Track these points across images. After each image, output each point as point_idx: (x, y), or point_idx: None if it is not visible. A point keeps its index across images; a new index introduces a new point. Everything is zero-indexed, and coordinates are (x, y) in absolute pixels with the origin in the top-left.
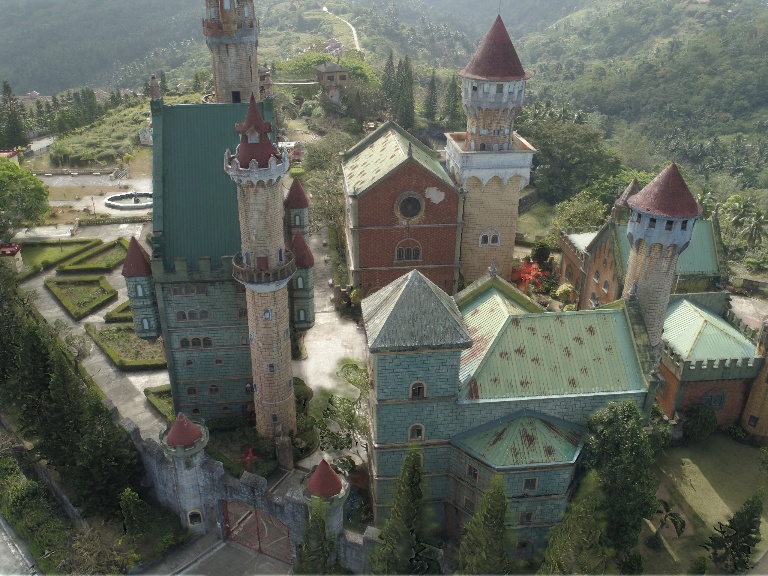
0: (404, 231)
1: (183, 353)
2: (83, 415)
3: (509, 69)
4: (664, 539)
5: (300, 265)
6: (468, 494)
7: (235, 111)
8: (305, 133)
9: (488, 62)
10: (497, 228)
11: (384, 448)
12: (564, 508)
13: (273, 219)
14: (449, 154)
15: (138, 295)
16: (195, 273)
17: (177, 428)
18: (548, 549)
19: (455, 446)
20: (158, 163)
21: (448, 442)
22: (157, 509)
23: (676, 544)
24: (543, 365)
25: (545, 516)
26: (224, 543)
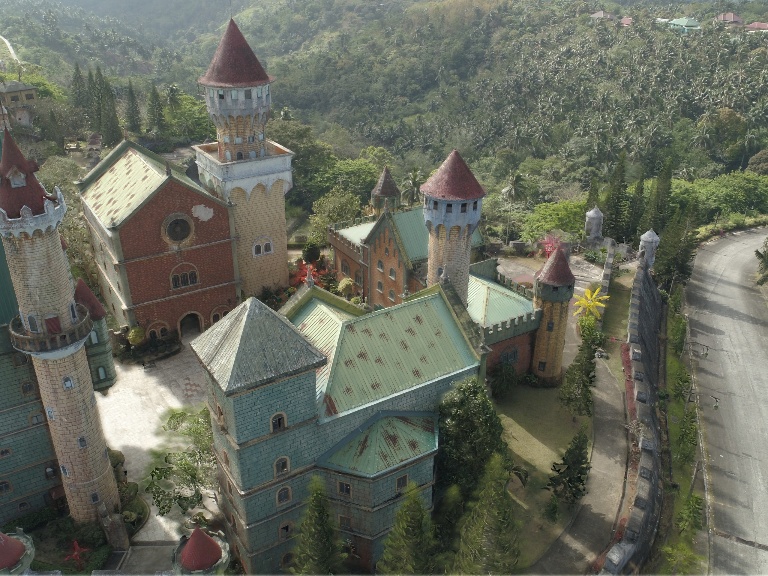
0: (176, 256)
1: None
2: None
3: (253, 74)
4: (510, 493)
5: (91, 317)
6: (342, 512)
7: None
8: None
9: (231, 68)
10: (268, 236)
11: (251, 493)
12: (431, 494)
13: (58, 272)
14: (203, 168)
15: None
16: None
17: None
18: (464, 540)
19: (322, 468)
20: None
21: (314, 466)
22: None
23: (521, 494)
24: (387, 364)
25: None
26: None
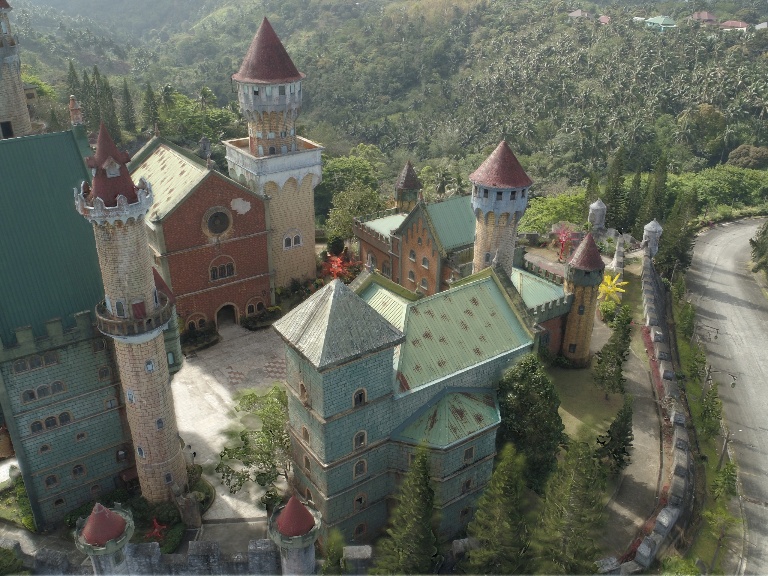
0: (215, 249)
1: (35, 439)
2: None
3: (287, 70)
4: None
5: None
6: None
7: (39, 144)
8: None
9: (265, 65)
10: (298, 229)
11: (333, 466)
12: None
13: (145, 259)
14: (235, 163)
15: None
16: (44, 341)
17: (98, 522)
18: (550, 499)
19: (395, 441)
20: None
21: (388, 440)
22: None
23: None
24: (450, 343)
25: (480, 479)
26: None
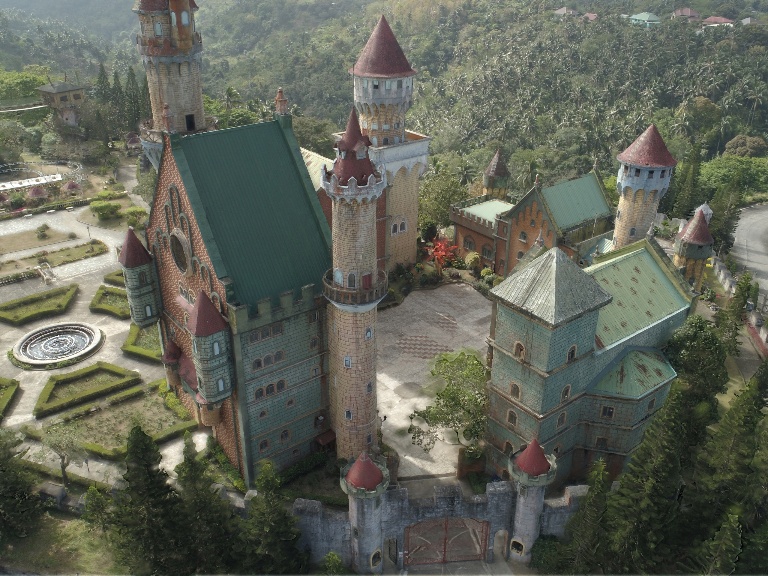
0: None
1: (257, 406)
2: (214, 504)
3: (403, 65)
4: None
5: None
6: (601, 433)
7: (253, 133)
8: (60, 163)
9: (385, 60)
10: (404, 216)
11: (545, 417)
12: None
13: None
14: None
15: (214, 354)
16: (278, 312)
17: (366, 469)
18: None
19: (590, 395)
20: (197, 203)
21: (584, 394)
22: (318, 571)
23: None
24: (626, 306)
25: None
26: (405, 571)
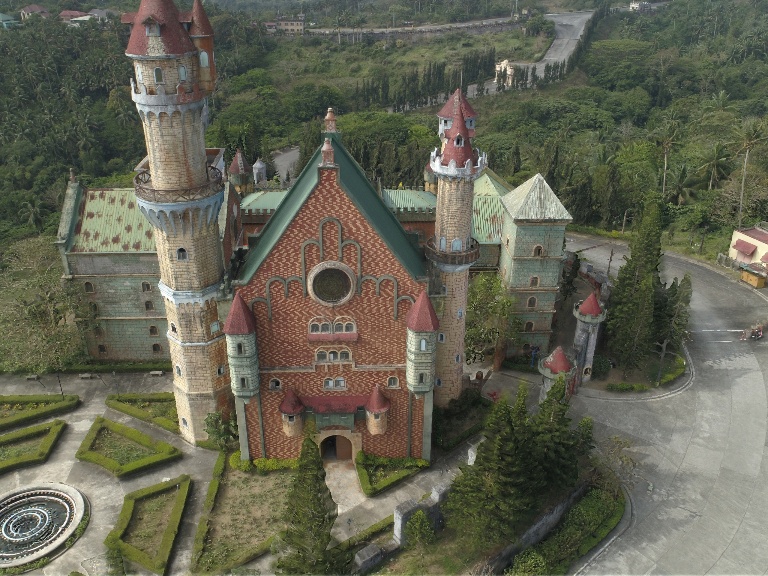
0: None
1: None
2: None
3: None
4: None
5: None
6: None
7: None
8: None
9: None
10: None
11: None
12: None
13: None
14: None
15: None
16: None
17: None
18: None
19: None
20: (373, 223)
21: None
22: None
23: None
24: None
25: None
26: None
